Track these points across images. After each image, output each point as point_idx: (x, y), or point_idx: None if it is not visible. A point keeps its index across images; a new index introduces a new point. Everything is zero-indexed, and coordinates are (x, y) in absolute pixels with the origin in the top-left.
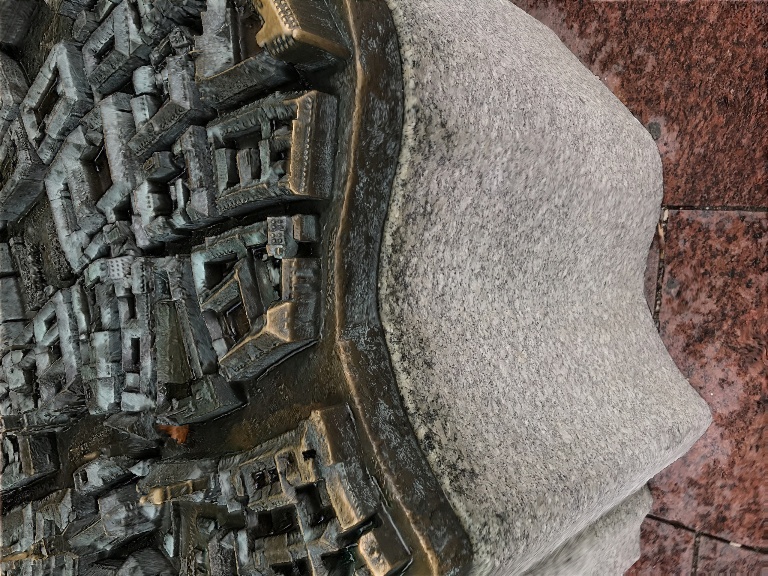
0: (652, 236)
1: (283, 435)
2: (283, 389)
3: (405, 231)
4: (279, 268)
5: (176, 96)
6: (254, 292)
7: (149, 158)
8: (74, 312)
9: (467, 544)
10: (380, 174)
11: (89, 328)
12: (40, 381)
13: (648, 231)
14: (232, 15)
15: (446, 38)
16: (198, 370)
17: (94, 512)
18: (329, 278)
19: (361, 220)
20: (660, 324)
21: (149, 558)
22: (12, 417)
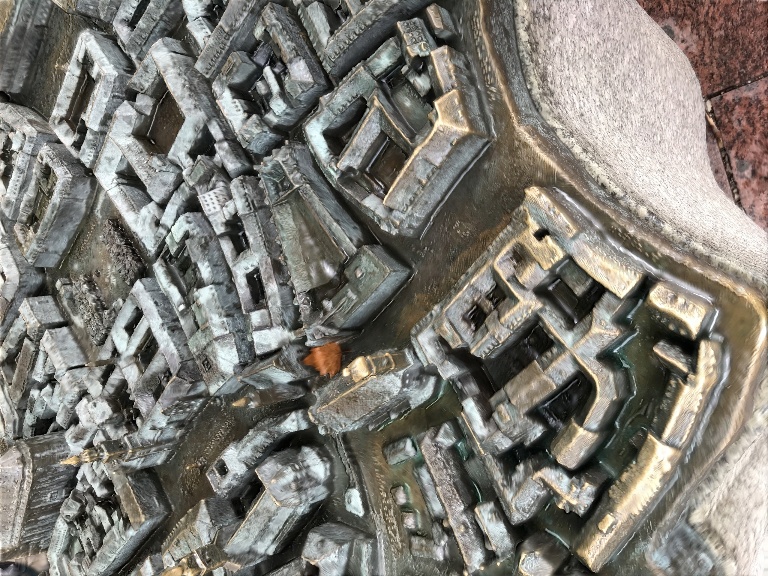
0: (704, 127)
1: (495, 240)
2: (459, 226)
3: (535, 31)
4: (426, 72)
5: None
6: (399, 119)
7: None
8: (164, 289)
9: (761, 295)
10: None
11: (186, 299)
12: (135, 394)
13: (701, 120)
14: None
15: None
16: (349, 246)
17: (240, 517)
18: (485, 66)
19: (495, 8)
20: (746, 210)
21: (333, 530)
22: (112, 441)
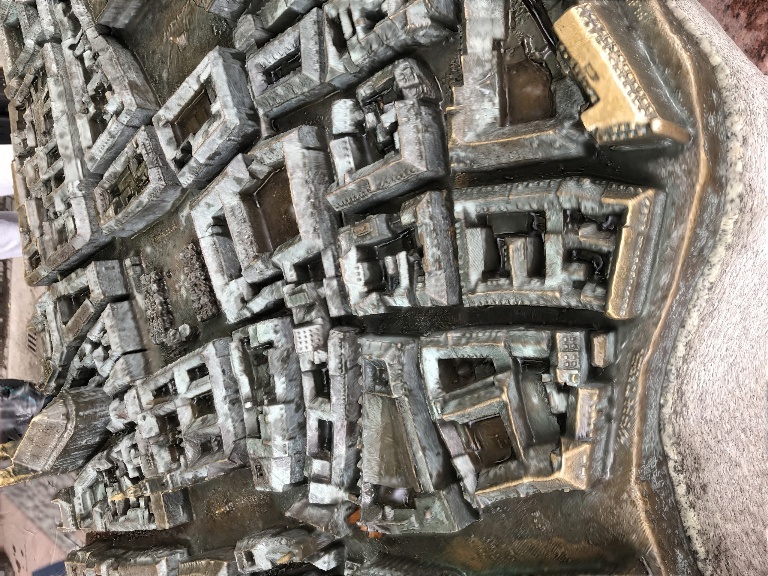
0: None
1: None
2: (538, 517)
3: (694, 336)
4: (566, 394)
5: (409, 153)
6: (521, 412)
7: (364, 223)
8: (235, 373)
9: None
10: (692, 279)
11: (254, 393)
12: (184, 438)
13: None
14: (498, 60)
15: (751, 92)
16: (428, 484)
17: None
18: (627, 408)
19: (665, 335)
20: None
21: None
22: (156, 479)
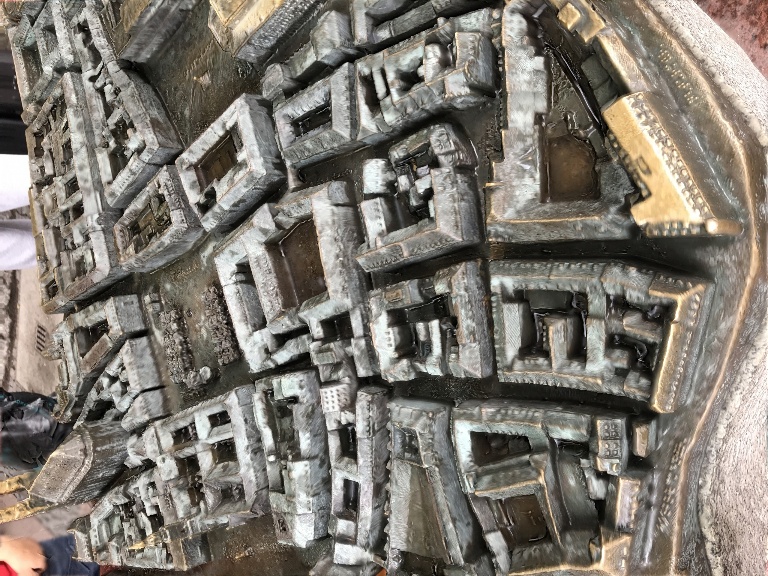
0: None
1: None
2: None
3: None
4: (605, 481)
5: (445, 223)
6: (557, 494)
7: (396, 290)
8: (258, 425)
9: None
10: None
11: (277, 446)
12: (205, 484)
13: None
14: (540, 134)
15: None
16: (458, 556)
17: None
18: (668, 496)
19: None
20: None
21: None
22: (176, 526)
